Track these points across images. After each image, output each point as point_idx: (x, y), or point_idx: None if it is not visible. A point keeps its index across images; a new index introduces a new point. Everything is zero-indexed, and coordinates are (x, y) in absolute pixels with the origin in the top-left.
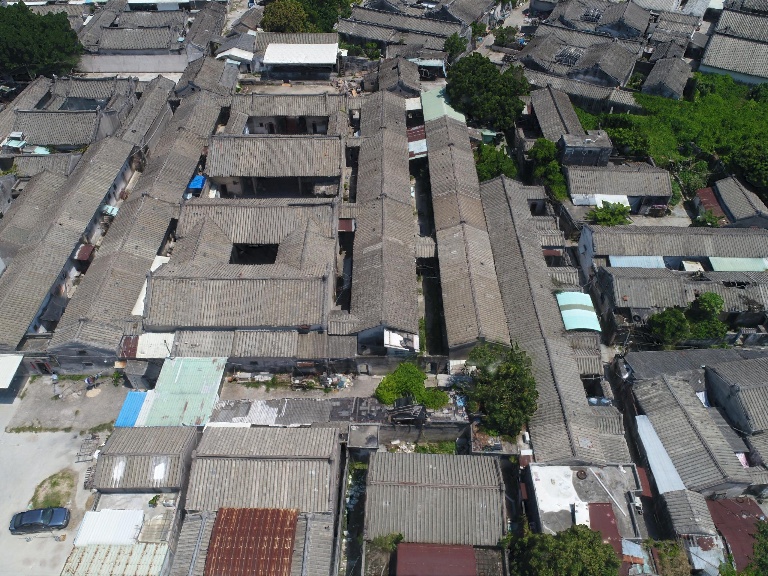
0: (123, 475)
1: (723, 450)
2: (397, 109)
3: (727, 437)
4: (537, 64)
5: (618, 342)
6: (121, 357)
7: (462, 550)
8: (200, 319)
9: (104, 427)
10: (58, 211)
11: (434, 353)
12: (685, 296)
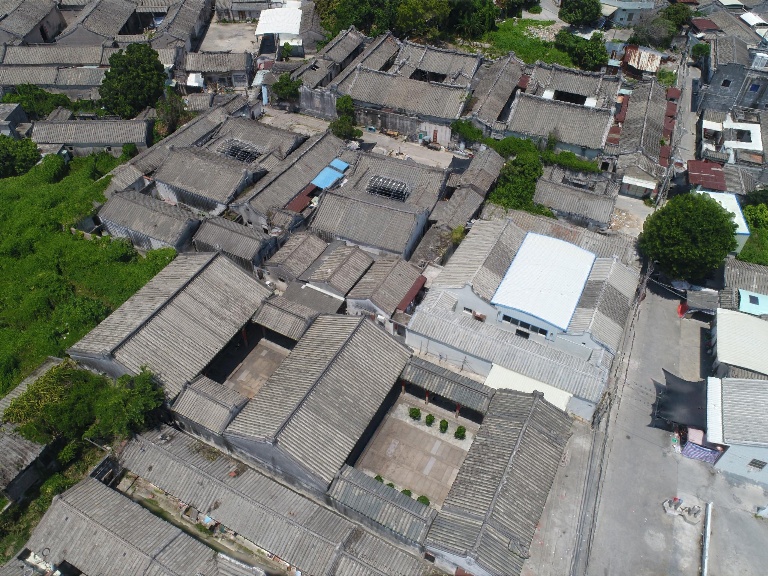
0: None
1: None
2: None
3: None
4: None
5: None
6: None
7: None
8: None
9: None
10: None
11: None
12: None
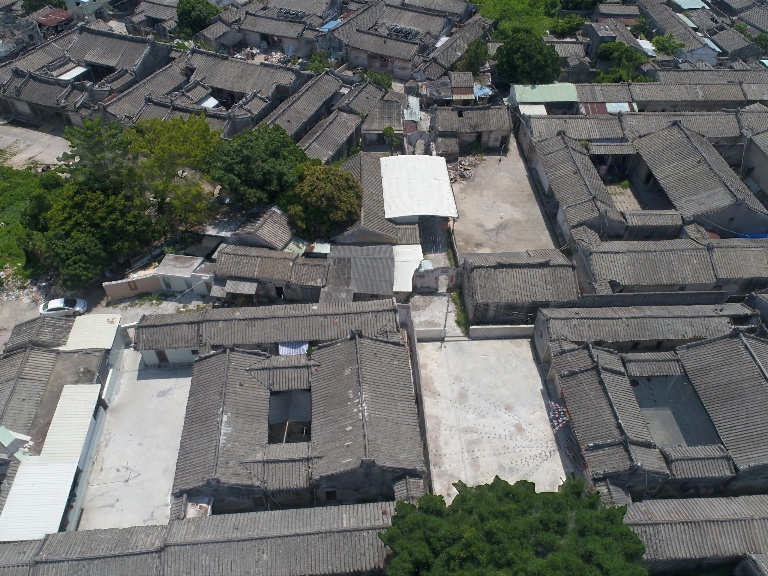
0: None
1: None
2: None
3: None
4: (424, 46)
5: None
6: None
7: None
8: None
9: None
10: None
11: None
12: None
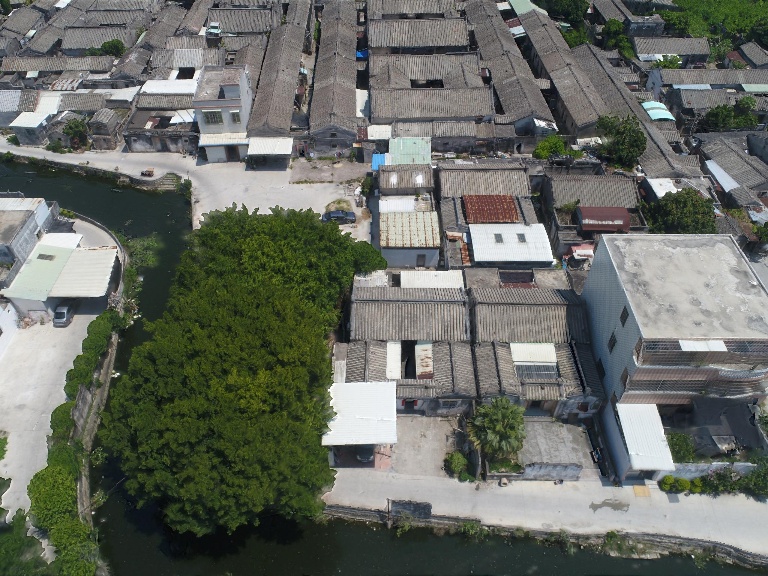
0: (397, 181)
1: (764, 171)
2: (493, 8)
3: (765, 168)
4: None
5: (684, 134)
6: (358, 139)
7: None
8: (410, 113)
9: (355, 180)
10: (277, 63)
11: None
12: (729, 101)
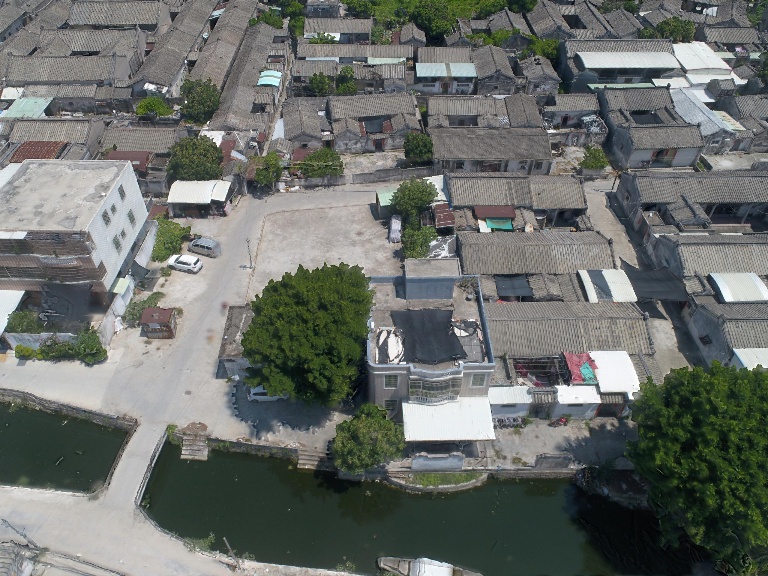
0: None
1: (313, 126)
2: None
3: (322, 124)
4: None
5: None
6: None
7: None
8: (38, 77)
9: None
10: None
11: None
12: (335, 70)
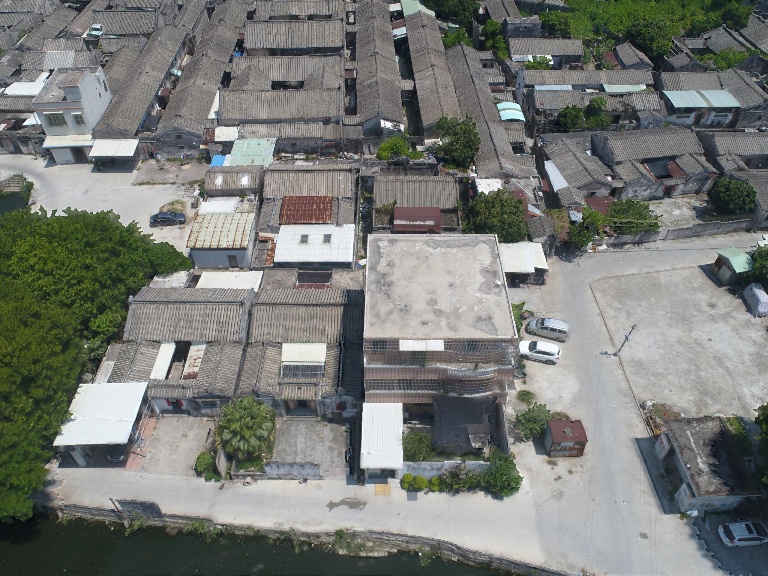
0: (222, 183)
1: (596, 171)
2: (383, 10)
3: (600, 168)
4: None
5: None
6: (205, 140)
7: (432, 207)
8: (257, 115)
9: (197, 181)
10: (143, 65)
11: (414, 144)
12: (583, 102)
